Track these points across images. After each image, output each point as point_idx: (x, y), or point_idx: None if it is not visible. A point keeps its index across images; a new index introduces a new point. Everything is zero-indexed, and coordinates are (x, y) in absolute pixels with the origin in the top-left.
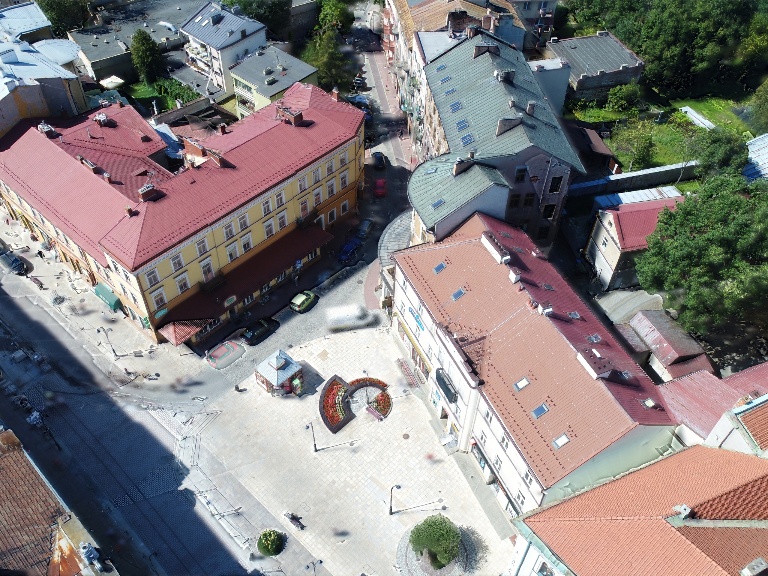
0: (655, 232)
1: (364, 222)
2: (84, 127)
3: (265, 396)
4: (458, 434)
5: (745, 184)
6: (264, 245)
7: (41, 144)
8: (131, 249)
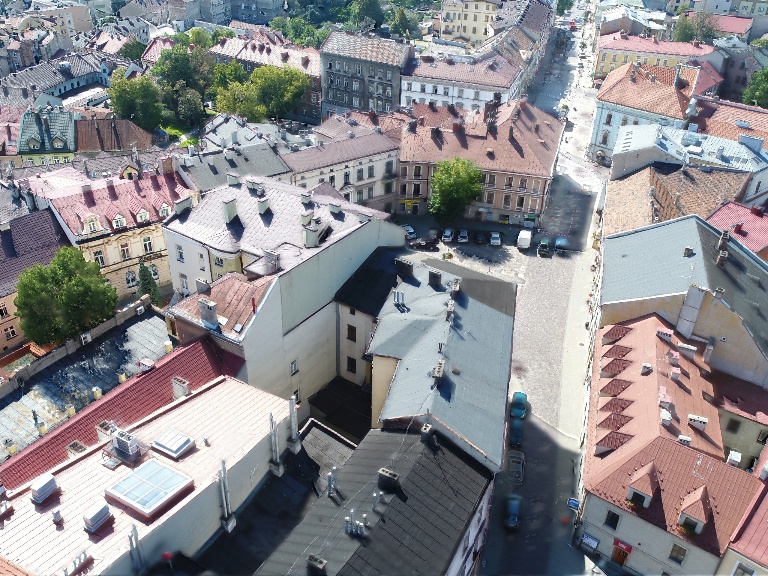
0: None
1: None
2: None
3: None
4: None
5: None
6: None
7: (617, 34)
8: None
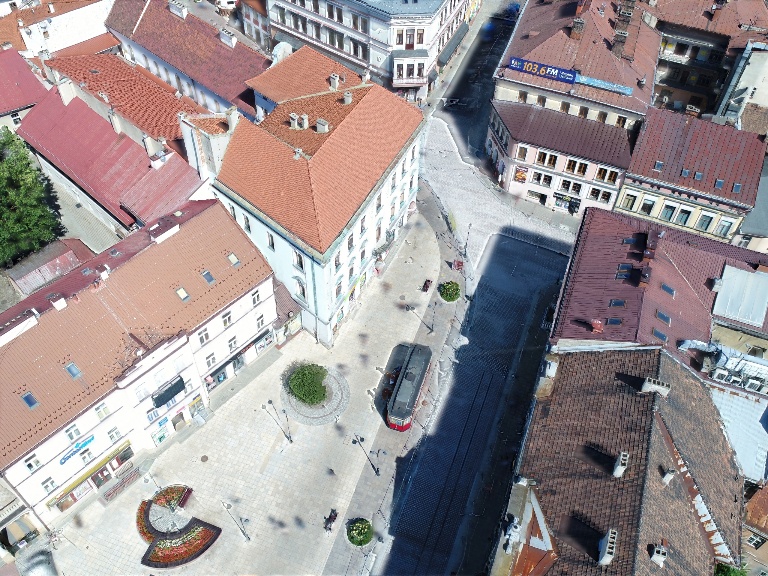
0: None
1: None
2: None
3: None
4: None
5: None
6: None
7: None
8: None
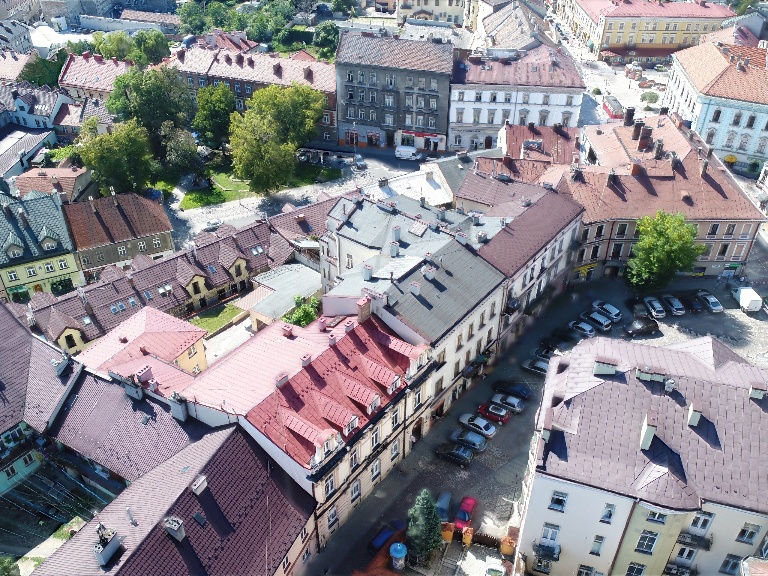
0: None
1: None
2: None
3: (624, 77)
4: None
5: None
6: (659, 46)
7: None
8: None
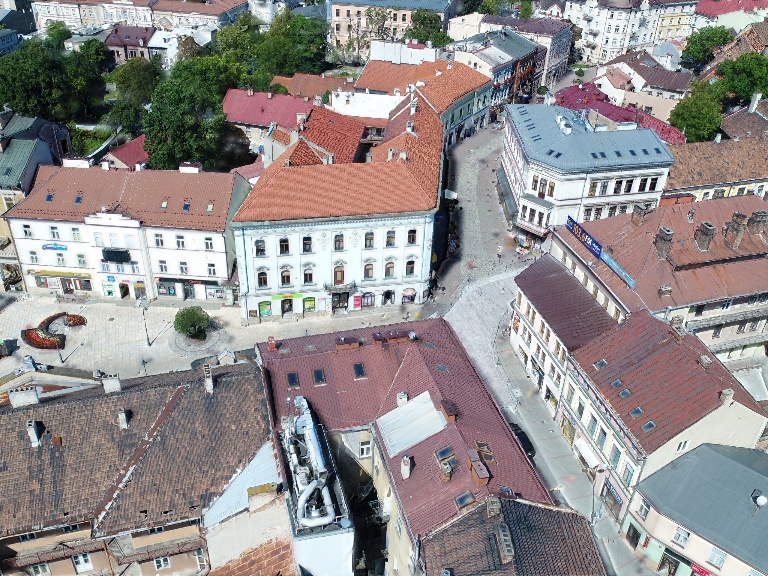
0: (145, 142)
1: None
2: None
3: None
4: (144, 287)
5: (173, 84)
6: None
7: None
8: None
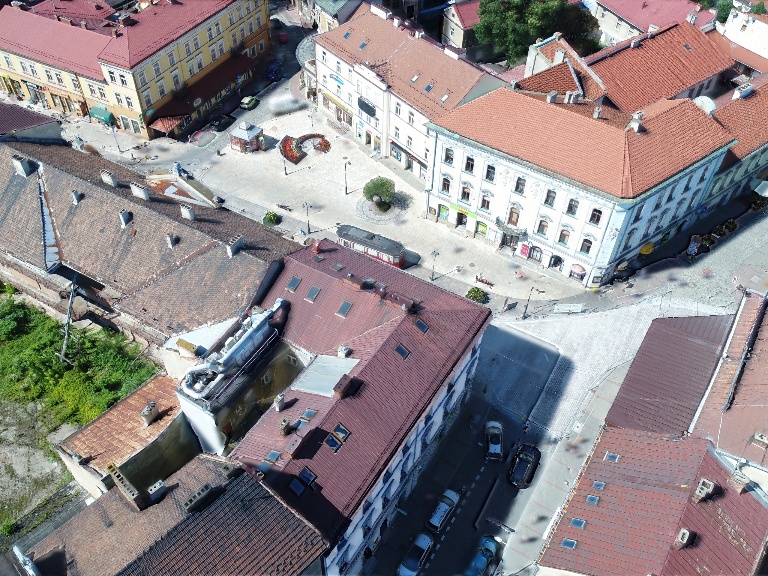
0: None
1: (278, 55)
2: (48, 2)
3: (240, 154)
4: (380, 143)
5: None
6: (211, 67)
7: (18, 15)
8: (125, 56)
